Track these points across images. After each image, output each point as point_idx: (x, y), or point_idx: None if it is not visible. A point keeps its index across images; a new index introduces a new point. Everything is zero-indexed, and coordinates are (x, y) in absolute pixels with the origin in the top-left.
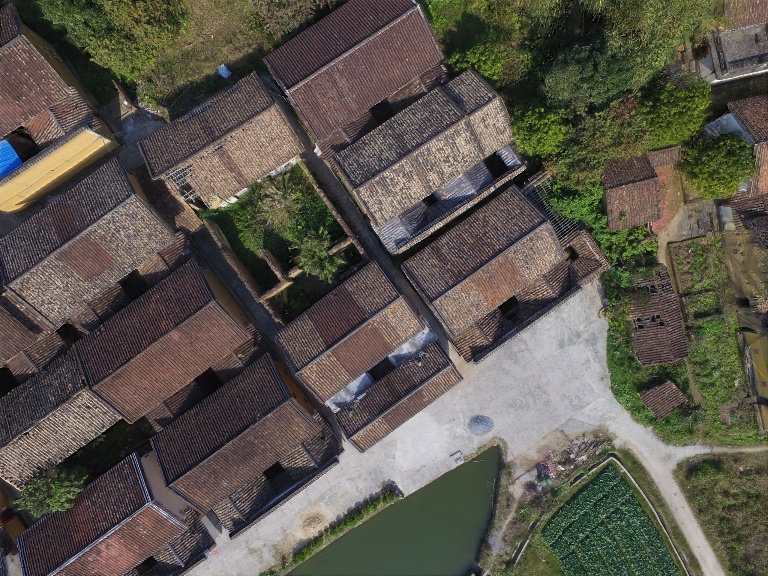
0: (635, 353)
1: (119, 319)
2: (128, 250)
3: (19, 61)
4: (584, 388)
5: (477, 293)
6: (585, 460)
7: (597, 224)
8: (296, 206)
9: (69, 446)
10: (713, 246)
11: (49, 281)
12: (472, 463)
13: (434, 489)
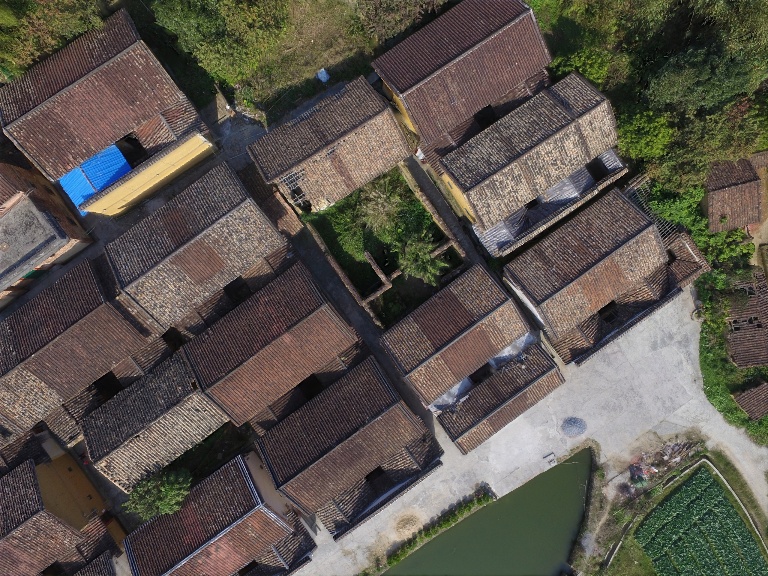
0: (729, 355)
1: (227, 322)
2: (239, 254)
3: (136, 66)
4: (677, 390)
5: (582, 296)
6: (678, 462)
7: (696, 226)
8: (395, 209)
9: (176, 449)
10: None
11: (162, 285)
12: (565, 465)
13: (526, 491)
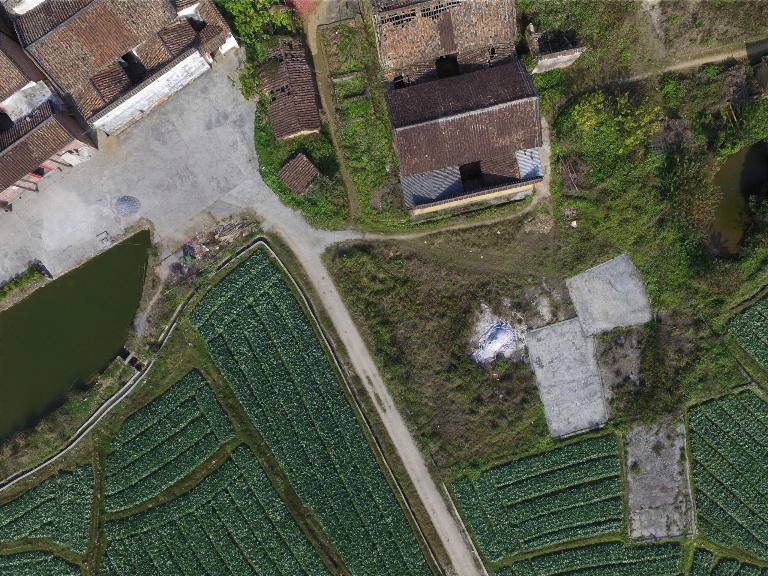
0: None
1: None
2: None
3: None
4: (232, 170)
5: (79, 44)
6: (231, 242)
7: None
8: None
9: None
10: (362, 29)
11: None
12: (121, 245)
13: (85, 272)
